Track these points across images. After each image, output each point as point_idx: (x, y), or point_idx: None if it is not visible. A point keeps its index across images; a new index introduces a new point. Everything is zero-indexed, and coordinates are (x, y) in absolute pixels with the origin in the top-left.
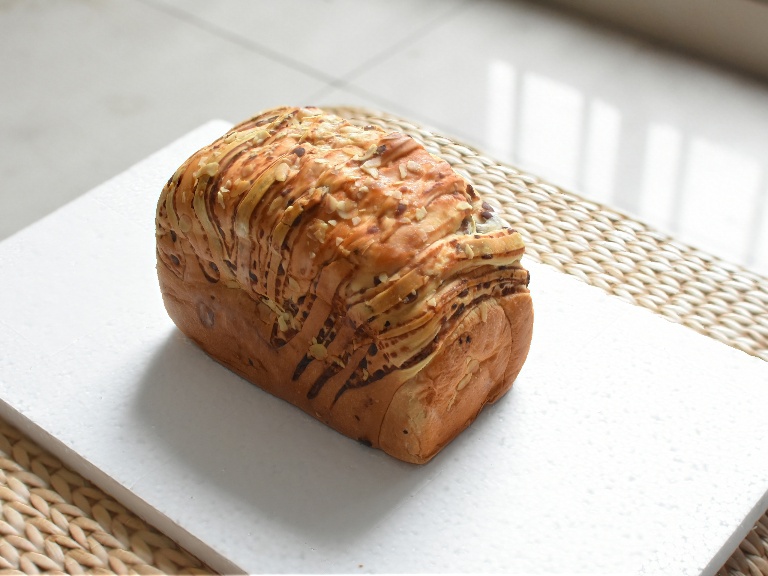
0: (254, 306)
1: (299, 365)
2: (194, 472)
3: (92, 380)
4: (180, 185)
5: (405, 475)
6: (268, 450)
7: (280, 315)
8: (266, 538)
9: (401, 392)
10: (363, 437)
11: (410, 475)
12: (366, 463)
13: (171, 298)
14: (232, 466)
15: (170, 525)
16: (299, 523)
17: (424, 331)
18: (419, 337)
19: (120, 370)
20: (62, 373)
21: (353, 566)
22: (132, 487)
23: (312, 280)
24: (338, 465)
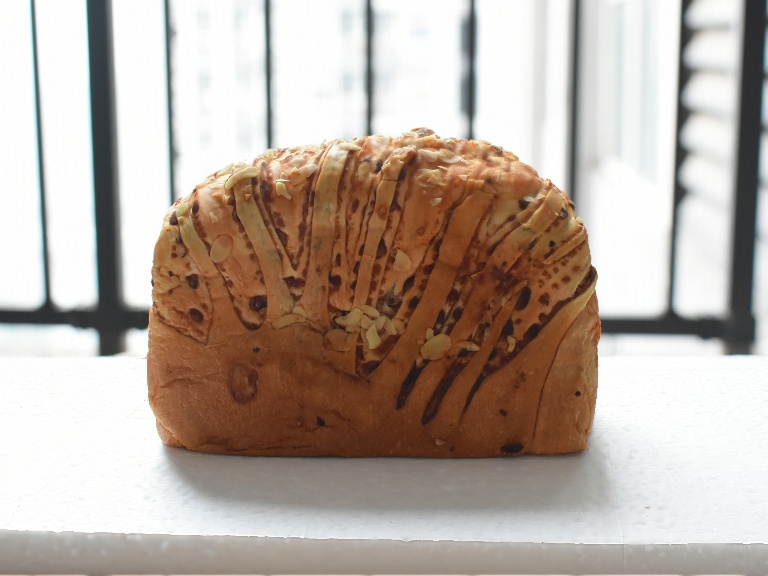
0: (320, 338)
1: (405, 383)
2: (362, 509)
3: (120, 495)
4: (200, 209)
5: (578, 462)
6: (415, 482)
7: (369, 326)
8: (522, 519)
9: (572, 335)
10: (512, 439)
11: (584, 460)
12: (530, 464)
13: (181, 384)
14: (397, 497)
15: (389, 553)
16: (537, 504)
17: (586, 247)
18: (585, 254)
19: (144, 483)
20: (69, 500)
21: (640, 509)
22: (305, 536)
23: (432, 239)
24: (505, 472)
